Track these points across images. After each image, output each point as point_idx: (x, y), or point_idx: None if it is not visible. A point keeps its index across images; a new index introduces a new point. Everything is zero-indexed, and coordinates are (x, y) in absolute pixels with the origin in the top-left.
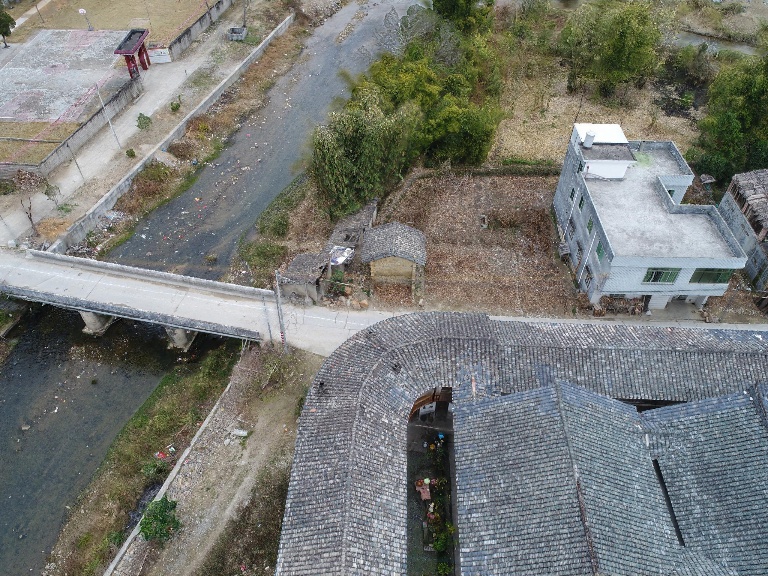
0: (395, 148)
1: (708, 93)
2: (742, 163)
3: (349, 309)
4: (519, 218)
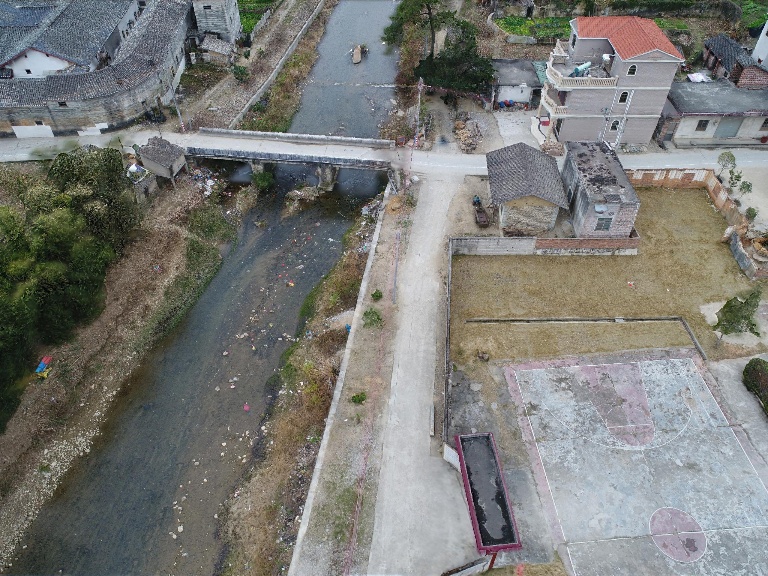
0: None
1: None
2: None
3: None
4: None
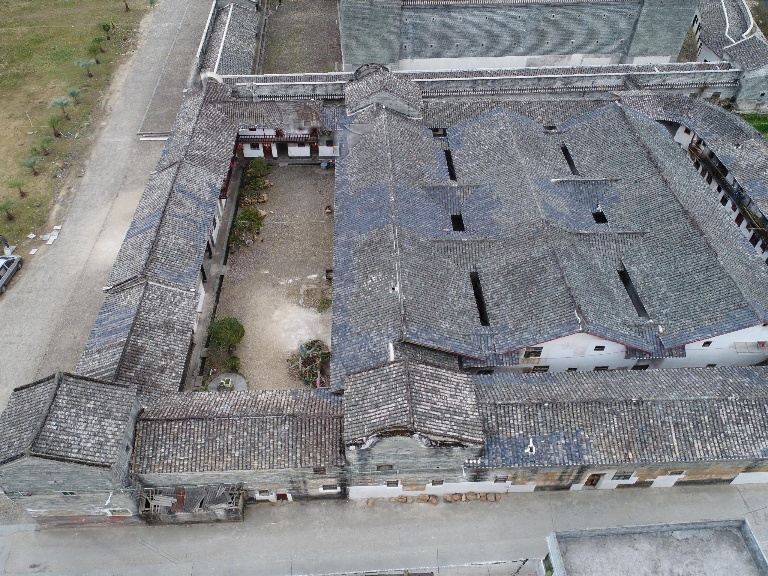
0: None
1: None
2: None
3: None
4: None
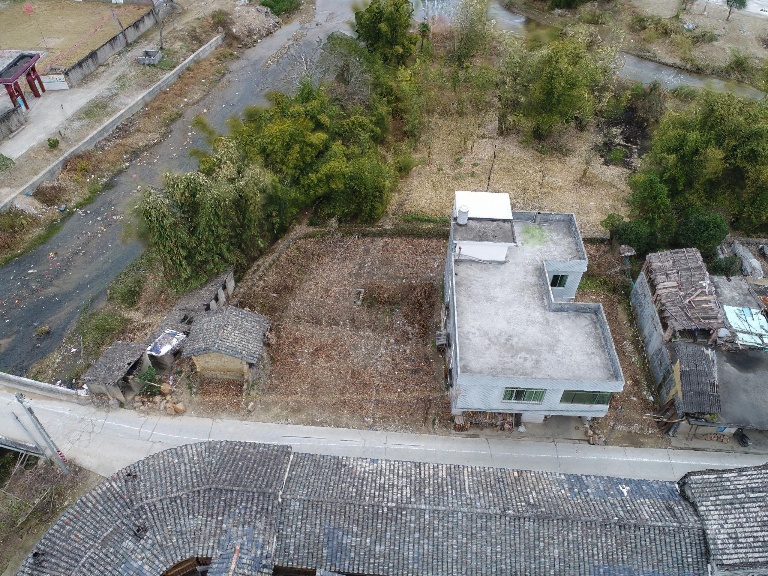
0: (252, 212)
1: (652, 140)
2: (671, 232)
3: (161, 414)
4: (398, 295)
